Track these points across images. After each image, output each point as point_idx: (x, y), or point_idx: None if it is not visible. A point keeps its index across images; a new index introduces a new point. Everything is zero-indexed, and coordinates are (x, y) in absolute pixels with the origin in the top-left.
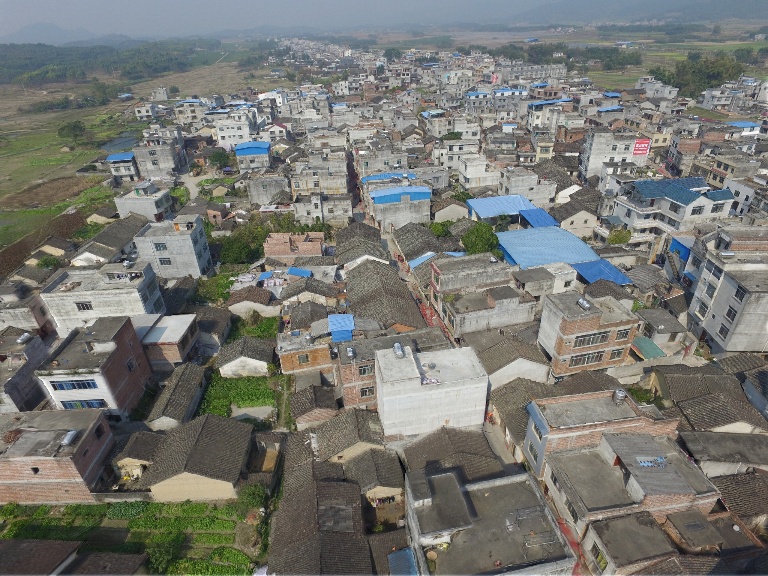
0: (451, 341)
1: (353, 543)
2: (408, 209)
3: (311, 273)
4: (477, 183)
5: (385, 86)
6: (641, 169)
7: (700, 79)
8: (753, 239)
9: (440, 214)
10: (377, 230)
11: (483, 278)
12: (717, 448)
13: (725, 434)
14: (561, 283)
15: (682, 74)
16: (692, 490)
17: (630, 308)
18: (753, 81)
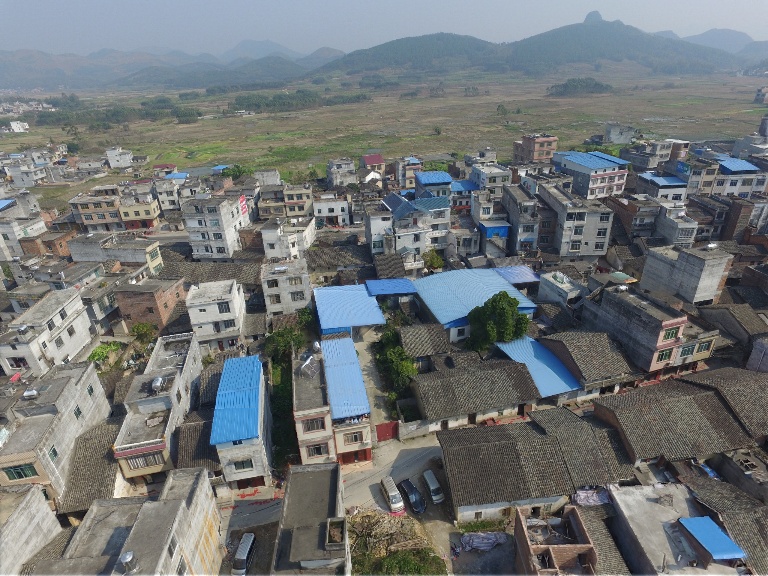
0: None
1: None
2: None
3: None
4: (240, 319)
5: None
6: None
7: None
8: None
9: None
10: (445, 432)
11: None
12: None
13: None
14: None
15: None
16: None
17: None
18: None
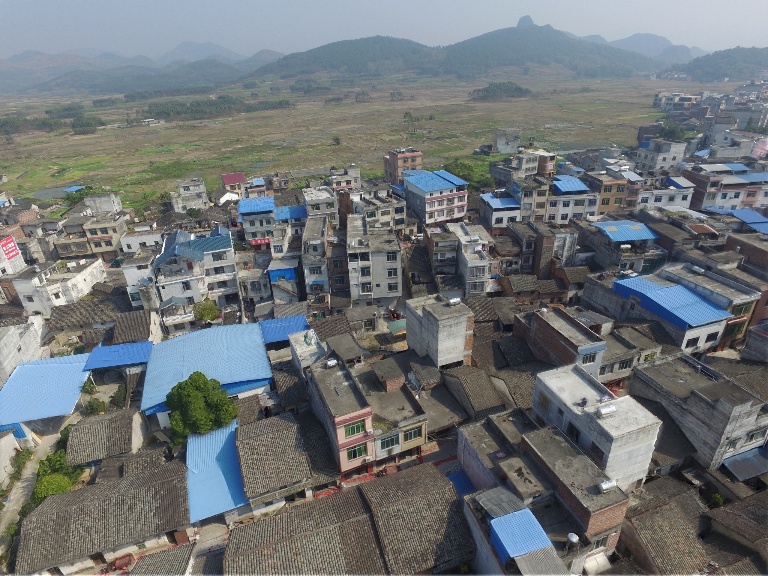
0: (398, 466)
1: (763, 504)
2: None
3: None
4: None
5: None
6: None
7: None
8: None
9: None
10: None
11: None
12: (511, 315)
13: (497, 310)
14: None
15: None
16: None
17: None
18: None
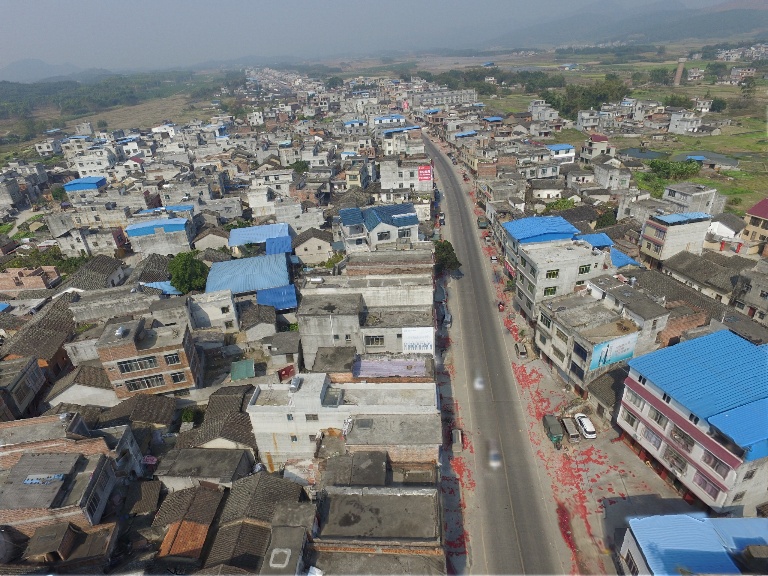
0: None
1: None
2: (165, 240)
3: (9, 307)
4: (262, 212)
5: None
6: (414, 195)
7: (589, 101)
8: (362, 264)
9: (200, 244)
10: (119, 262)
11: (121, 308)
12: (184, 463)
13: (207, 450)
14: (216, 310)
15: (571, 97)
16: (47, 504)
17: (274, 331)
18: (635, 102)
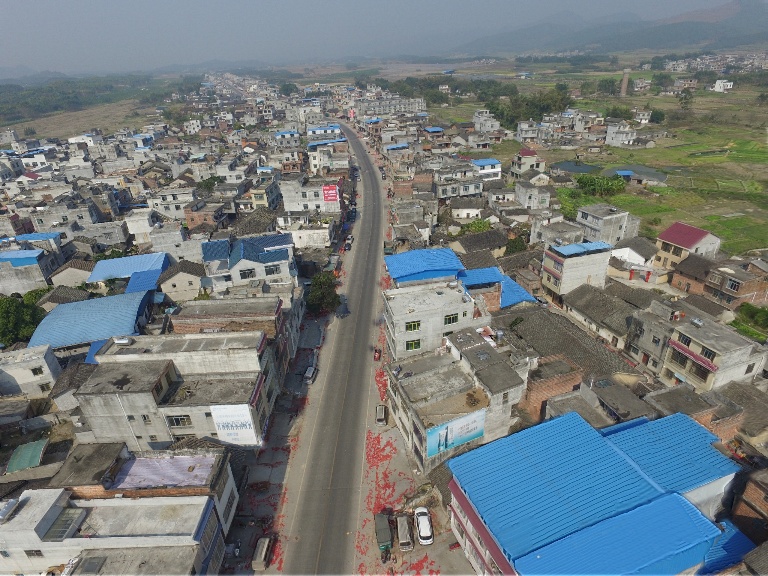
0: None
1: None
2: (14, 276)
3: None
4: (145, 238)
5: (243, 124)
6: (314, 218)
7: (533, 111)
8: (191, 317)
9: (58, 279)
10: None
11: None
12: None
13: None
14: (25, 371)
15: (515, 107)
16: None
17: None
18: (577, 113)
